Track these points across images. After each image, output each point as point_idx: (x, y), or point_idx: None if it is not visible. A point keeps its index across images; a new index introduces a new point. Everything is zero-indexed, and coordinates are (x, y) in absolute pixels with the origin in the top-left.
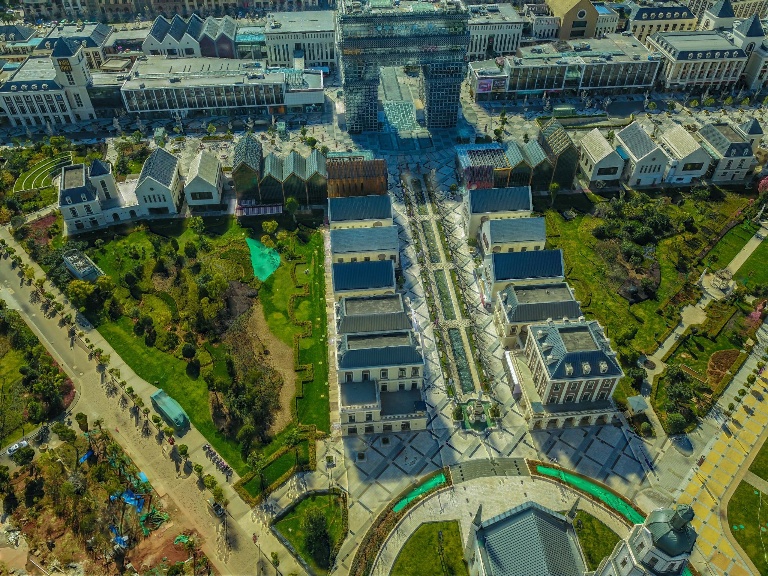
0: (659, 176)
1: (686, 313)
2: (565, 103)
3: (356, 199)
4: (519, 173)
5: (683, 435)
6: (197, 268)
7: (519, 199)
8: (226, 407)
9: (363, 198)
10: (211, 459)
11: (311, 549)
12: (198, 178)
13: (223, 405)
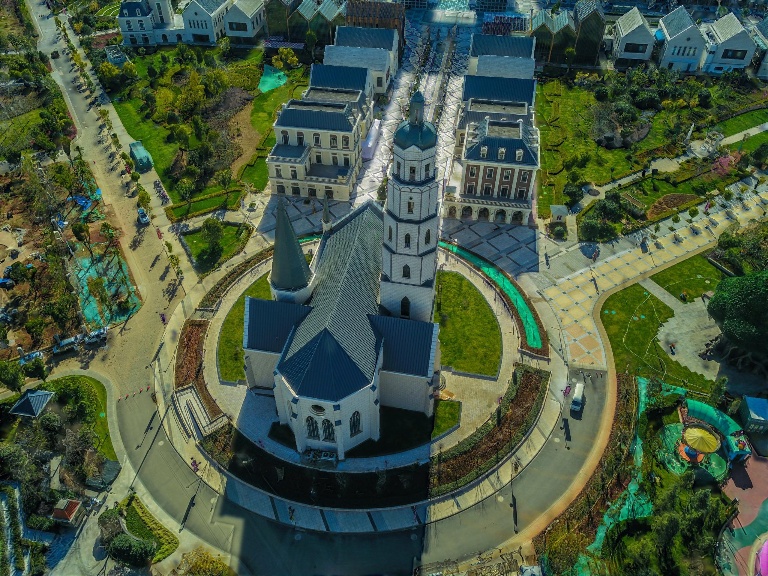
0: (694, 62)
1: (658, 163)
2: (628, 3)
3: (362, 30)
4: (539, 39)
5: (595, 243)
6: None
7: (521, 48)
8: (186, 161)
9: (369, 30)
10: (157, 190)
11: (205, 255)
12: (235, 7)
13: (184, 160)
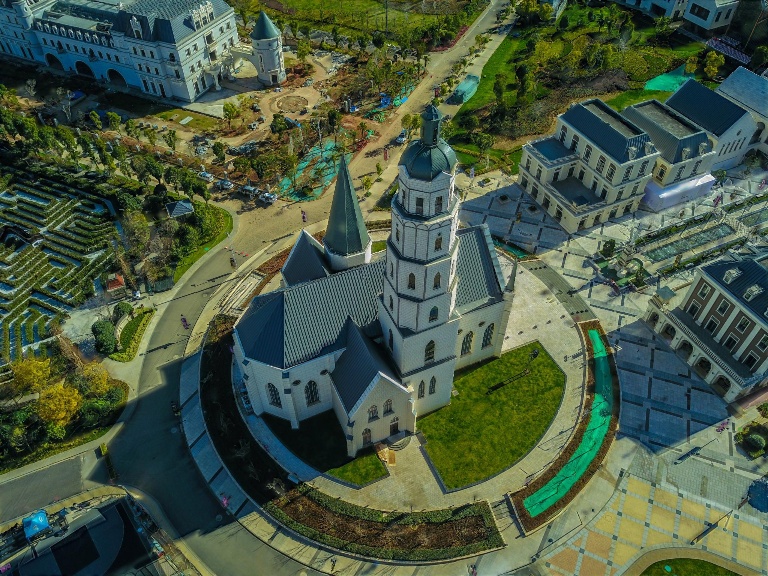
0: None
1: None
2: None
3: None
4: None
5: None
6: None
7: None
8: None
9: None
10: None
11: None
12: None
13: None
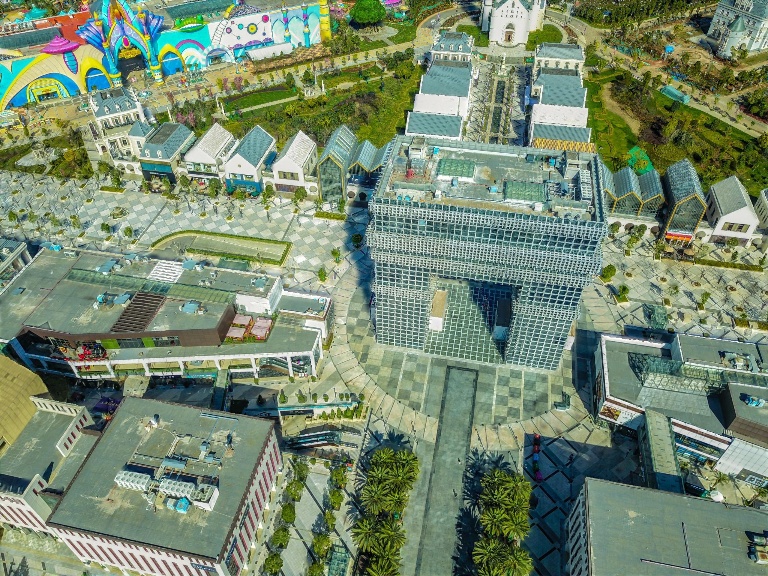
0: None
1: None
2: None
3: None
4: None
5: None
6: (696, 156)
7: None
8: None
9: None
10: None
11: None
12: None
13: None
